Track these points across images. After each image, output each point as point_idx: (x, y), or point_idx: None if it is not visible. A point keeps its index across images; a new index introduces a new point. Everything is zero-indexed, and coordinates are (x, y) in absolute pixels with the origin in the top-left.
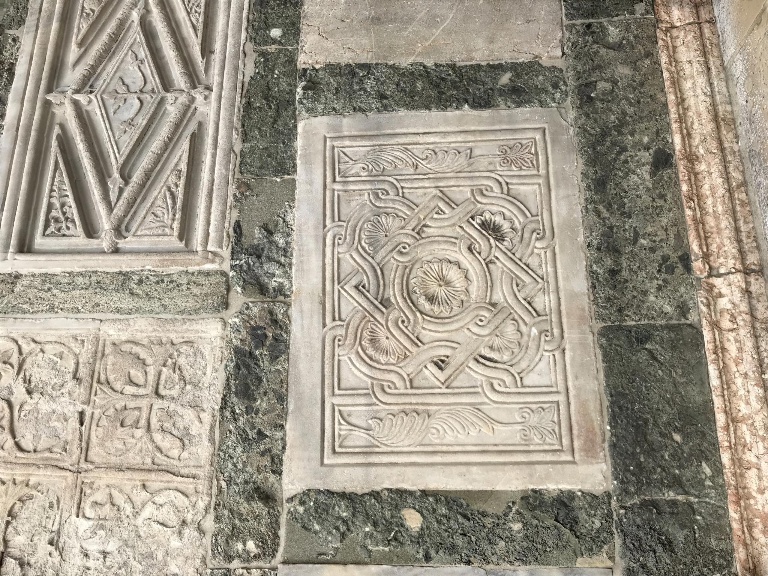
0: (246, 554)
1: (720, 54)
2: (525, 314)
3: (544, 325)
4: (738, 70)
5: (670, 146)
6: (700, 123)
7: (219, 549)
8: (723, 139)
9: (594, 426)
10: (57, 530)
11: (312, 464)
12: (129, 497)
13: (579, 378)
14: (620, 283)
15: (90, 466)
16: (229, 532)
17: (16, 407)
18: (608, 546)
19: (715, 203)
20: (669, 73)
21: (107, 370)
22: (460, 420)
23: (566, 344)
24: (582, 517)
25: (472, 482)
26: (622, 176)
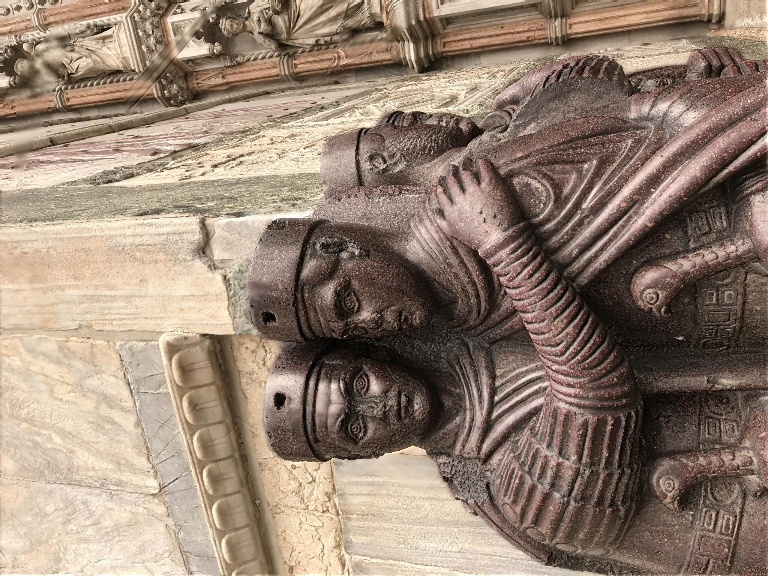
0: None
1: None
2: None
3: None
4: None
5: None
6: None
7: None
8: None
9: None
10: None
11: None
12: None
13: None
14: None
15: None
16: None
17: None
18: None
19: None
20: None
21: None
22: None
23: None
24: None
25: None
26: None
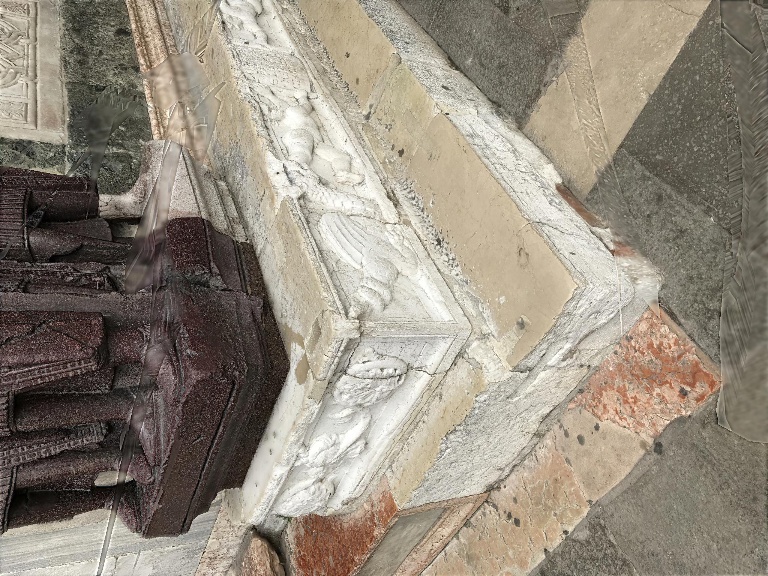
0: None
1: (163, 5)
2: (5, 63)
3: (20, 69)
4: (169, 1)
5: (129, 30)
6: (149, 24)
7: None
8: (163, 31)
9: (56, 117)
10: None
11: None
12: None
13: (47, 95)
14: (86, 68)
15: None
16: None
17: None
18: (59, 166)
19: (156, 50)
20: (130, 4)
21: None
22: None
23: (38, 81)
24: (38, 151)
25: None
26: (94, 32)
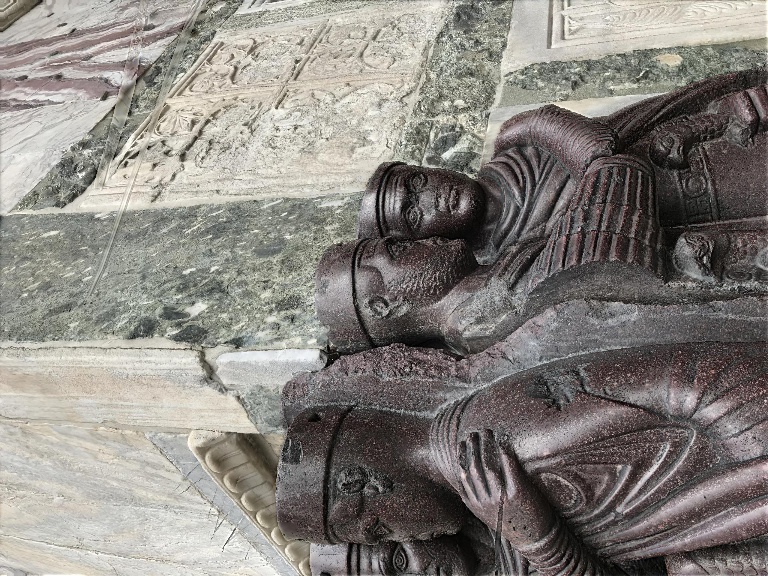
0: (453, 107)
1: None
2: None
3: None
4: None
5: None
6: None
7: (422, 108)
8: None
9: None
10: (254, 118)
11: (537, 49)
12: (331, 92)
13: None
14: None
15: (298, 82)
16: (435, 98)
17: (240, 68)
18: None
19: None
20: None
21: (329, 38)
22: (724, 2)
23: None
24: None
25: (749, 31)
26: None
